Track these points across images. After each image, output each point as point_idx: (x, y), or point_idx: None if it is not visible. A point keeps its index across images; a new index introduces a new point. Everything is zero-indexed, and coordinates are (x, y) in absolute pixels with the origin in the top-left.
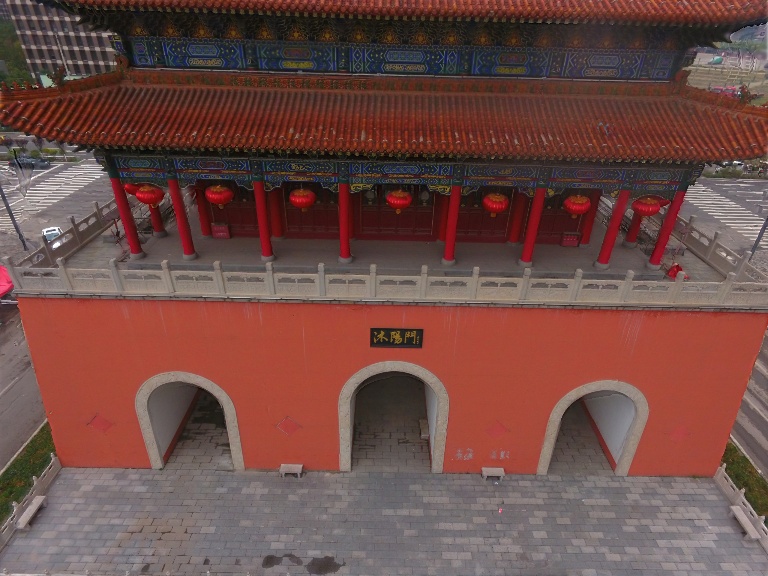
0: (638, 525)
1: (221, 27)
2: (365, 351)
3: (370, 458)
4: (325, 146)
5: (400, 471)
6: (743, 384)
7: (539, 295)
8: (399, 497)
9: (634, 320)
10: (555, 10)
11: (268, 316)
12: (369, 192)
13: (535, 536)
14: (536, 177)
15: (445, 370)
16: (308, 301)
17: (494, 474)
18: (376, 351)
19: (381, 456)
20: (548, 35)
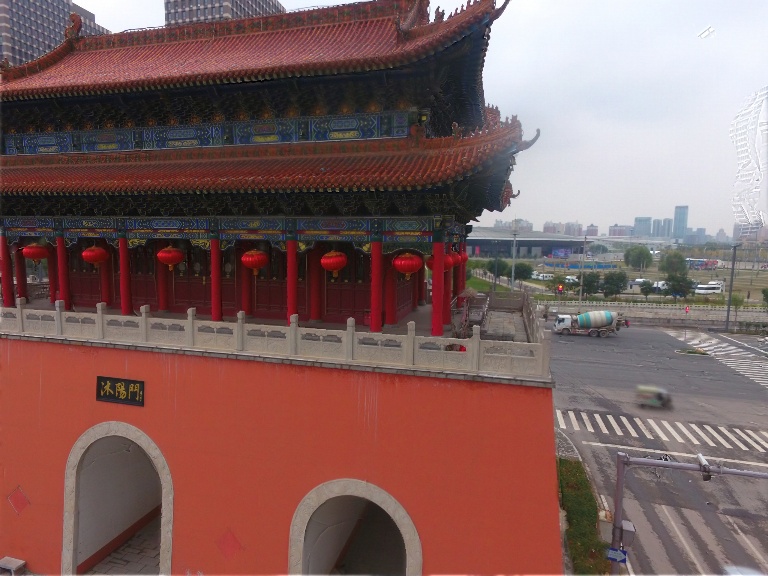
0: None
1: (57, 123)
2: (92, 405)
3: (108, 574)
4: (67, 187)
5: None
6: (553, 513)
7: (257, 346)
8: None
9: (368, 387)
10: (246, 69)
11: (15, 356)
12: (181, 264)
13: None
14: (283, 229)
15: (168, 440)
16: (45, 339)
17: None
18: (101, 406)
19: (122, 574)
20: (293, 108)
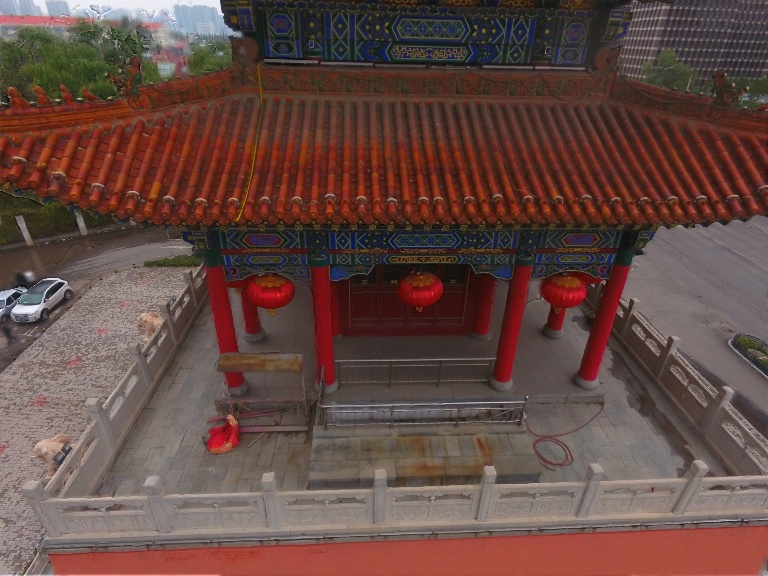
0: None
1: None
2: None
3: None
4: None
5: None
6: None
7: None
8: None
9: None
10: None
11: None
12: None
13: None
14: None
15: None
16: None
17: None
18: None
19: None
20: None
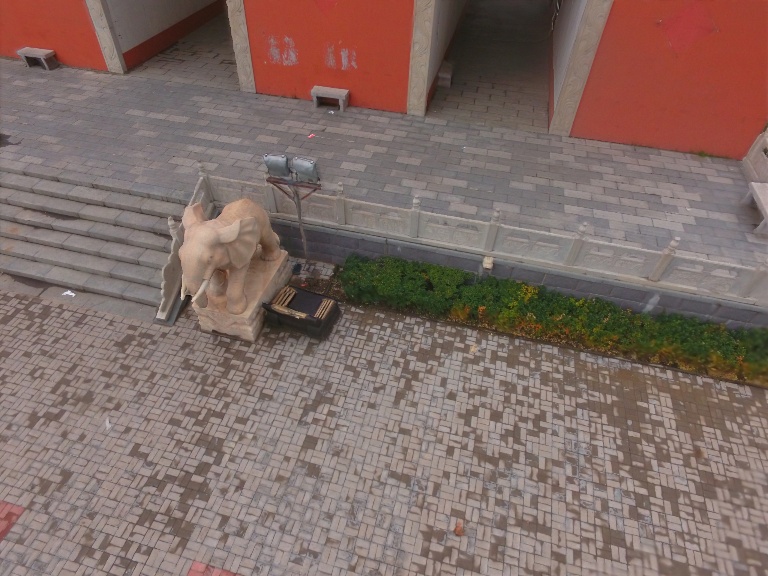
0: (544, 184)
1: None
2: None
3: (165, 68)
4: None
5: (195, 83)
6: None
7: None
8: (167, 103)
9: None
10: None
11: None
12: None
13: (343, 166)
14: None
15: None
16: None
17: (327, 93)
18: None
19: (182, 69)
20: None
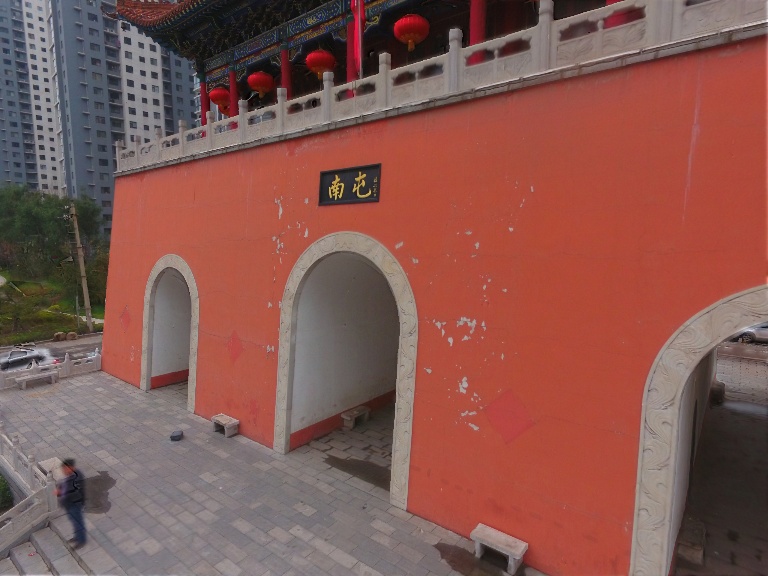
0: None
1: None
2: None
3: None
4: None
5: None
6: None
7: None
8: None
9: None
10: None
11: None
12: None
13: None
14: None
15: None
16: None
17: None
18: None
19: None
20: None
